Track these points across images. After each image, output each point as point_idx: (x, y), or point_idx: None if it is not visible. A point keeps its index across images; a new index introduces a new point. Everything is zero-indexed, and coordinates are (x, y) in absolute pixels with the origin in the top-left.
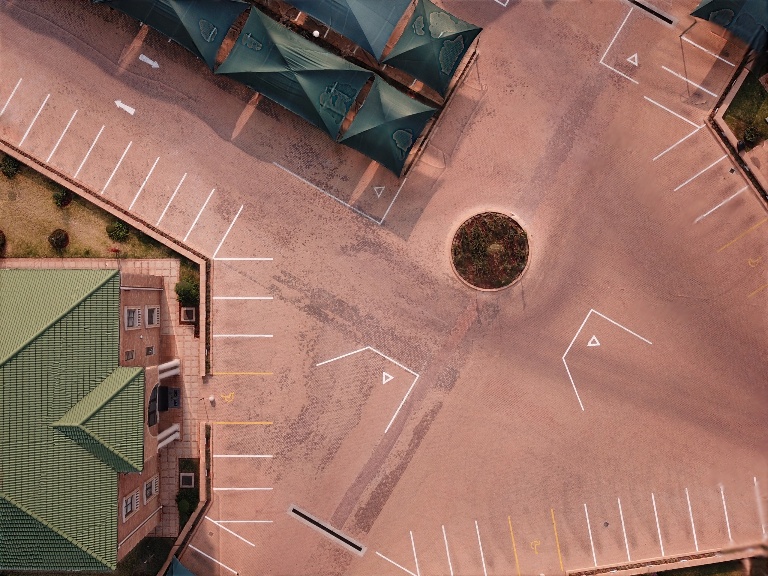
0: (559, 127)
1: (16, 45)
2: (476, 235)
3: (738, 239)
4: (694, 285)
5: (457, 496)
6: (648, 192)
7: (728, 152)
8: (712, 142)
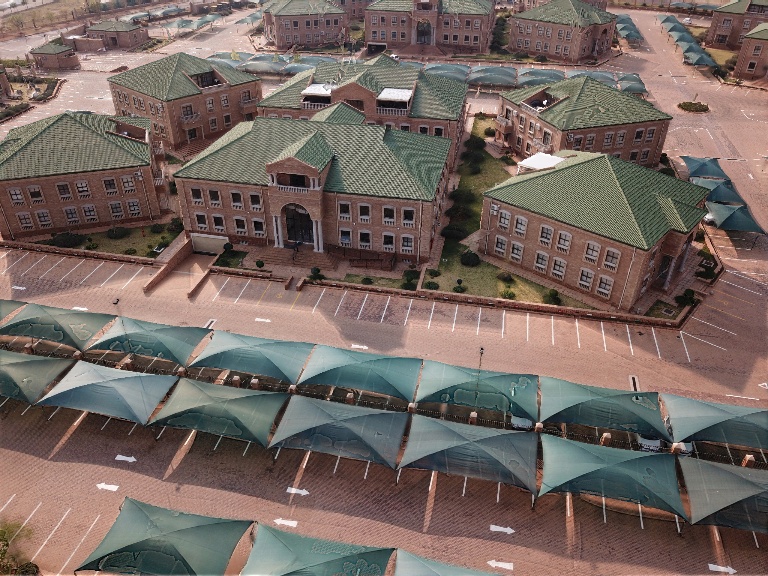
0: (681, 91)
1: (487, 103)
2: (685, 104)
3: (763, 95)
4: (764, 102)
5: (760, 144)
6: (724, 94)
7: (735, 86)
8: (728, 86)
